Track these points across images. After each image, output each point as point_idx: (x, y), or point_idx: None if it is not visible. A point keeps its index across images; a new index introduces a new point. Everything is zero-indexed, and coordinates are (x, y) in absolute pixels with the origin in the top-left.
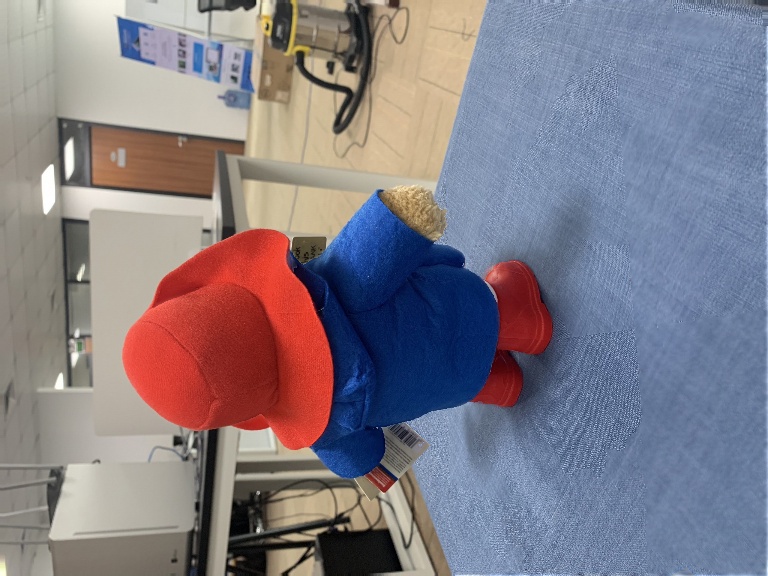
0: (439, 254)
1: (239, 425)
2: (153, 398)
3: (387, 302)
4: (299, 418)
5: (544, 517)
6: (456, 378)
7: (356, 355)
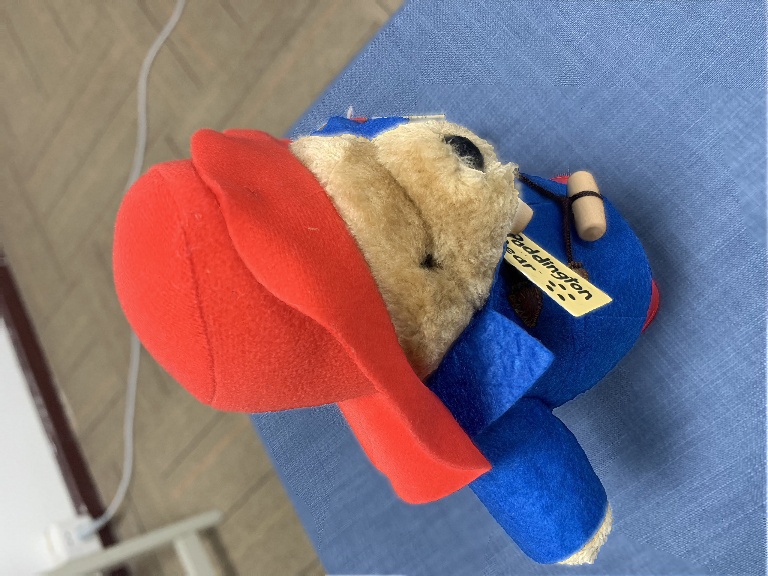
0: None
1: None
2: None
3: None
4: None
5: None
6: None
7: None
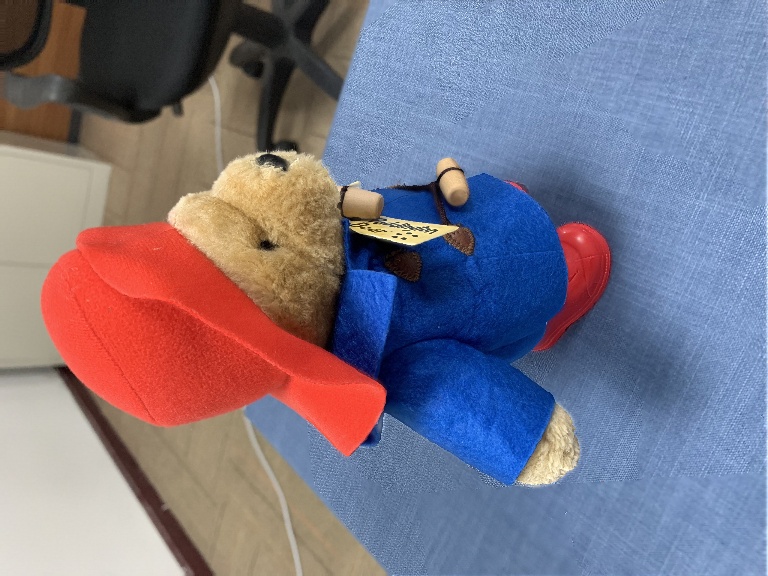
0: None
1: None
2: None
3: None
4: None
5: None
6: None
7: None
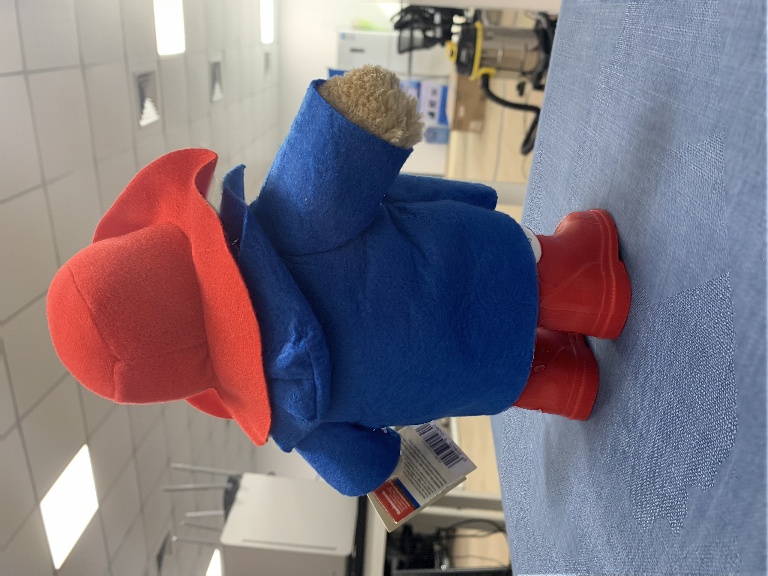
0: (451, 187)
1: (208, 410)
2: (61, 356)
3: (351, 243)
4: (244, 400)
5: None
6: (471, 363)
7: (292, 311)
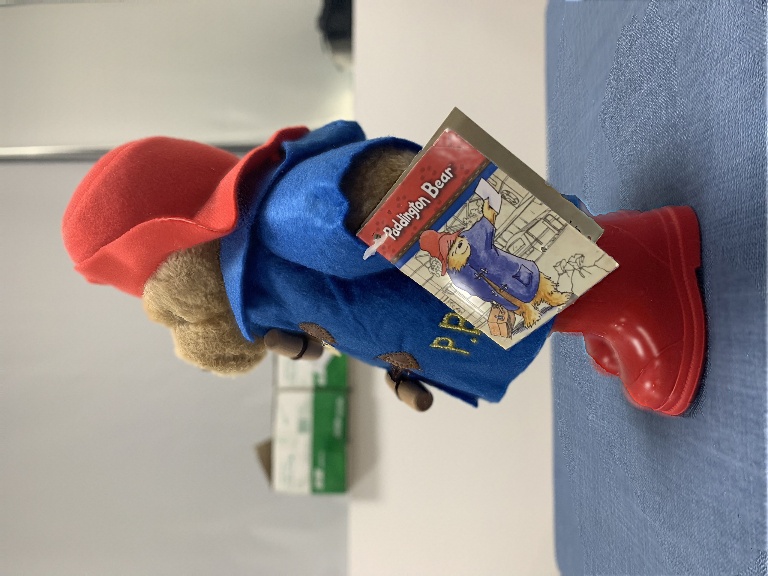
0: None
1: None
2: None
3: None
4: None
5: None
6: None
7: None
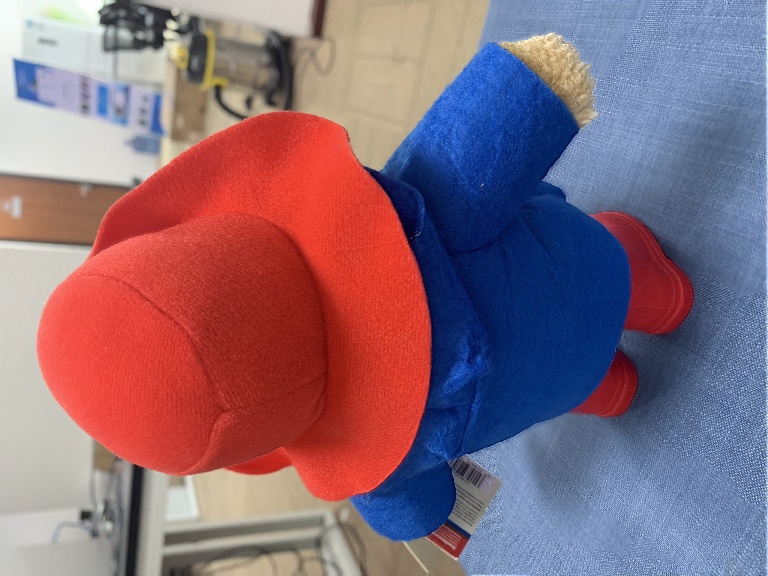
0: None
1: (237, 468)
2: (98, 418)
3: (495, 240)
4: (356, 444)
5: (712, 574)
6: (578, 368)
7: (465, 322)
